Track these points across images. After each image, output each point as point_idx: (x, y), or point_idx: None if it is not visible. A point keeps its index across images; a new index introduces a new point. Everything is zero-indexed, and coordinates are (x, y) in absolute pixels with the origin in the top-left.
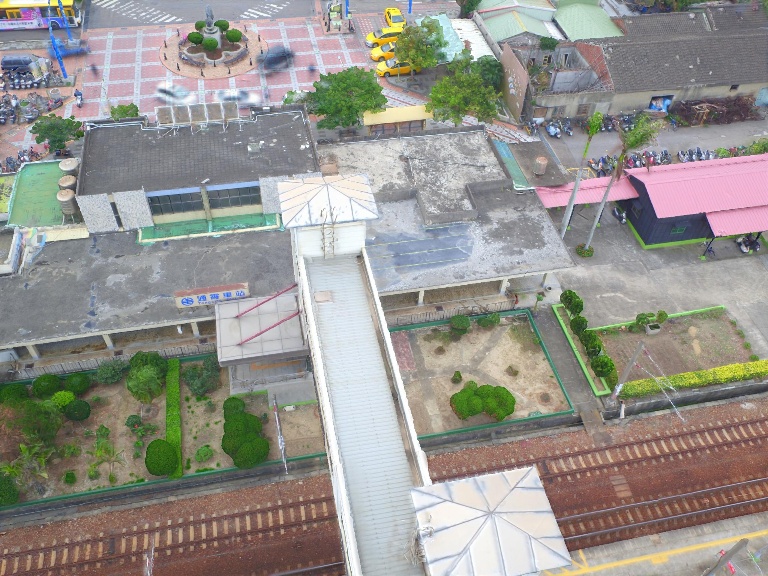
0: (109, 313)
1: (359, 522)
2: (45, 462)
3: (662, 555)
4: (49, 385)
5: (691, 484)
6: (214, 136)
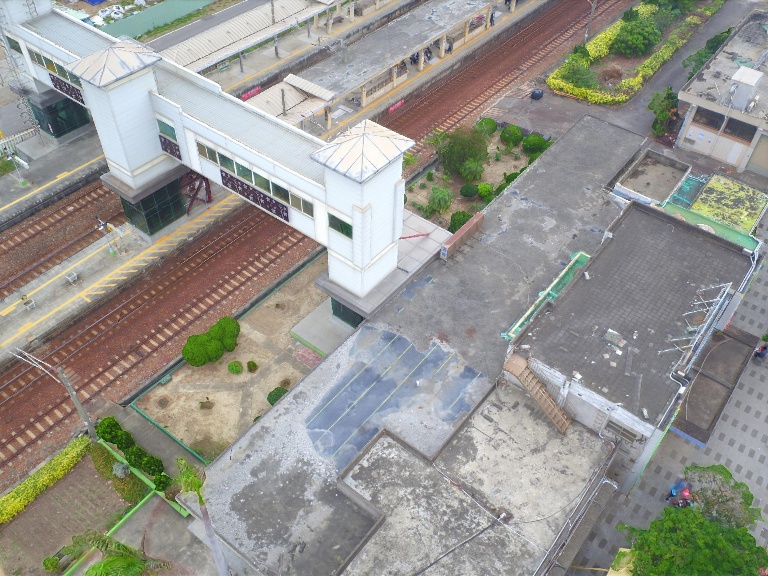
0: (516, 205)
1: (194, 86)
2: (431, 144)
3: (24, 330)
4: (501, 187)
5: (1, 414)
6: (666, 327)
